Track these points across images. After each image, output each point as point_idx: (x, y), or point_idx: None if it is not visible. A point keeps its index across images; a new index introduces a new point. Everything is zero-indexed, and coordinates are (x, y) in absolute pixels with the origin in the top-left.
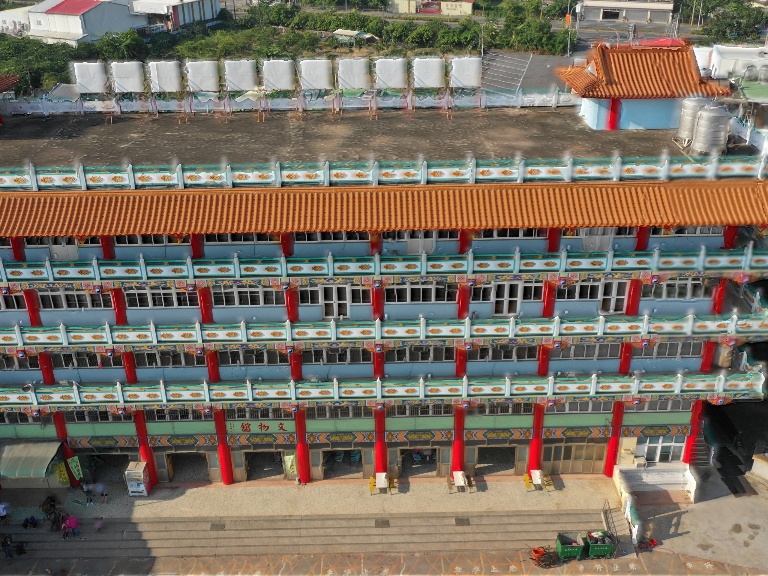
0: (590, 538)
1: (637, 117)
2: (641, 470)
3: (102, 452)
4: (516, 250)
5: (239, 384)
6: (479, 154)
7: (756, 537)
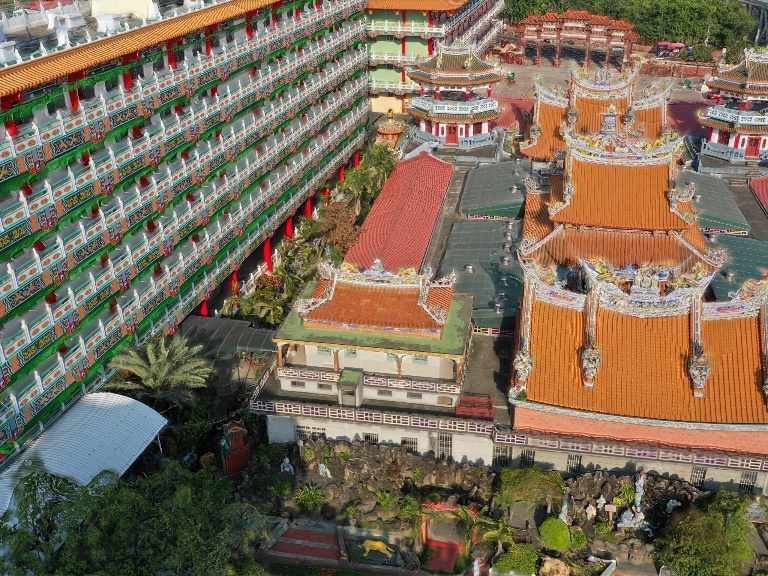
0: (512, 74)
1: None
2: None
3: None
4: None
5: None
6: None
7: None
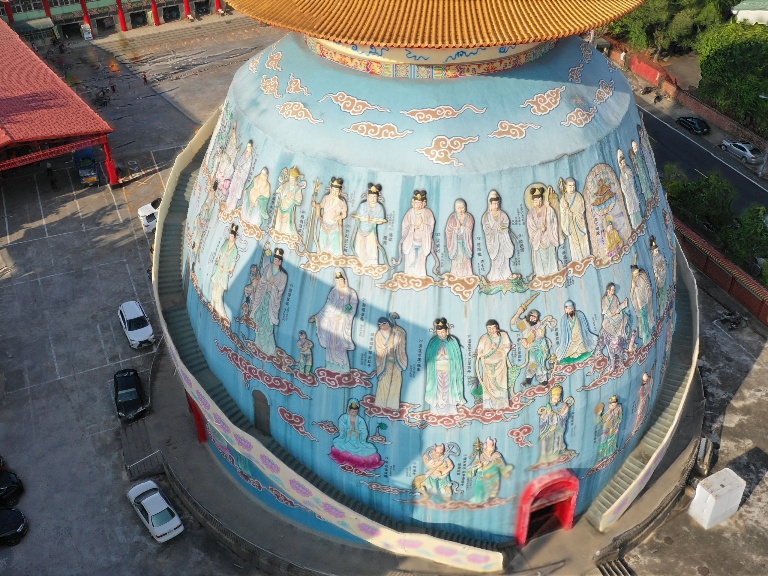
0: None
1: None
2: None
3: (67, 23)
4: None
5: None
6: None
7: None
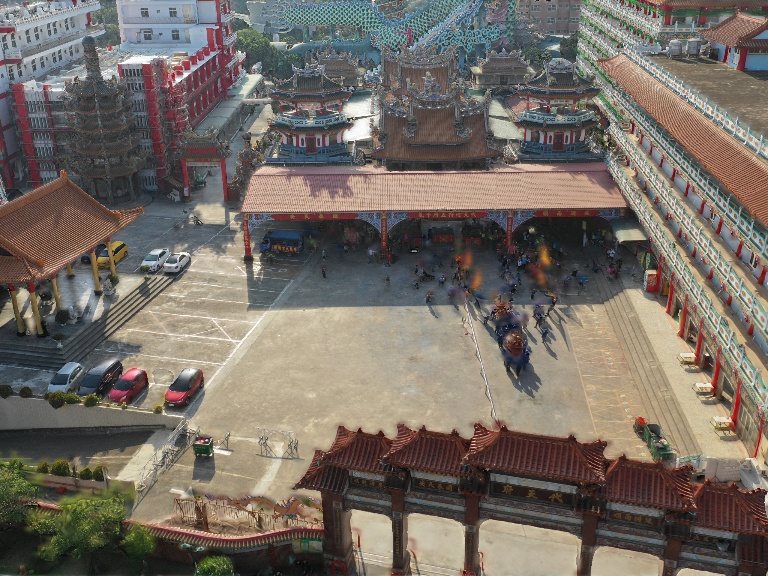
0: None
1: None
2: None
3: None
4: None
5: (680, 242)
6: None
7: None
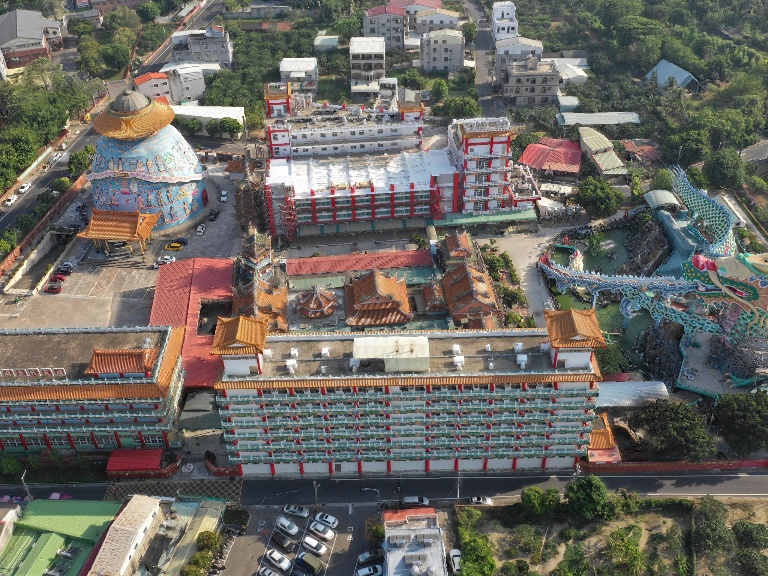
0: None
1: None
2: None
3: None
4: None
5: None
6: None
7: None
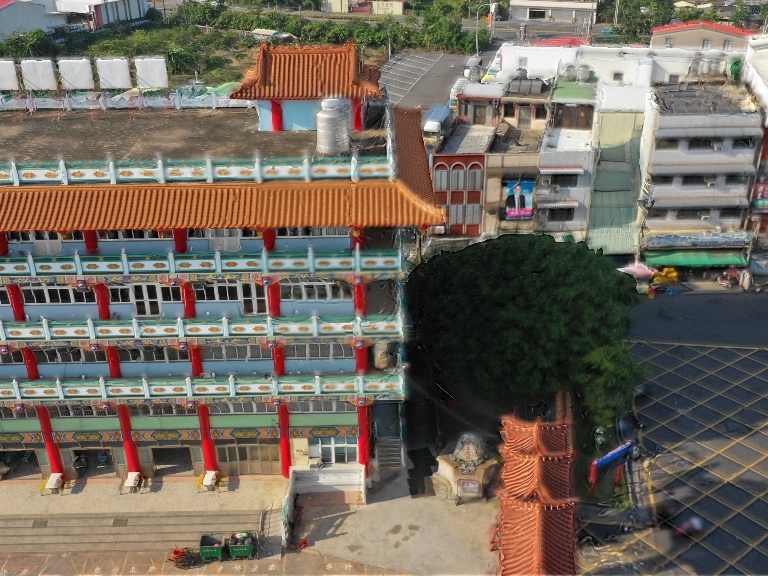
0: (231, 539)
1: (298, 118)
2: (315, 471)
3: None
4: (122, 251)
5: None
6: (114, 155)
7: (411, 538)
